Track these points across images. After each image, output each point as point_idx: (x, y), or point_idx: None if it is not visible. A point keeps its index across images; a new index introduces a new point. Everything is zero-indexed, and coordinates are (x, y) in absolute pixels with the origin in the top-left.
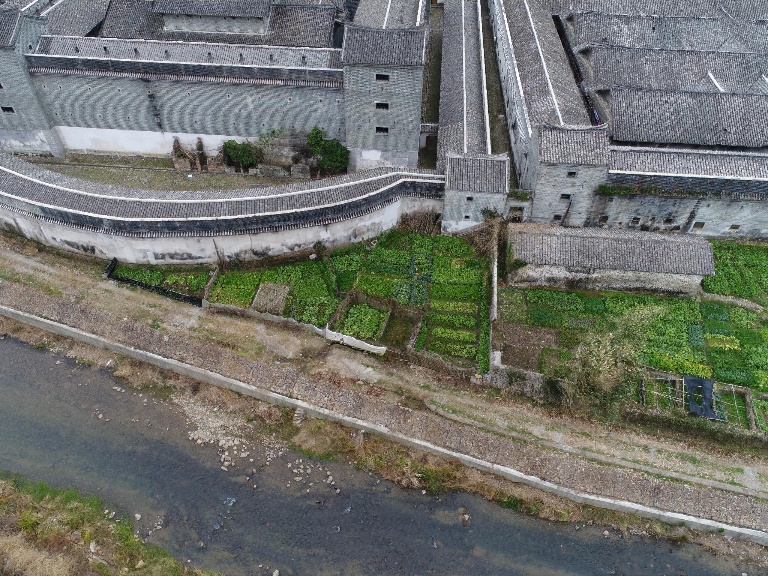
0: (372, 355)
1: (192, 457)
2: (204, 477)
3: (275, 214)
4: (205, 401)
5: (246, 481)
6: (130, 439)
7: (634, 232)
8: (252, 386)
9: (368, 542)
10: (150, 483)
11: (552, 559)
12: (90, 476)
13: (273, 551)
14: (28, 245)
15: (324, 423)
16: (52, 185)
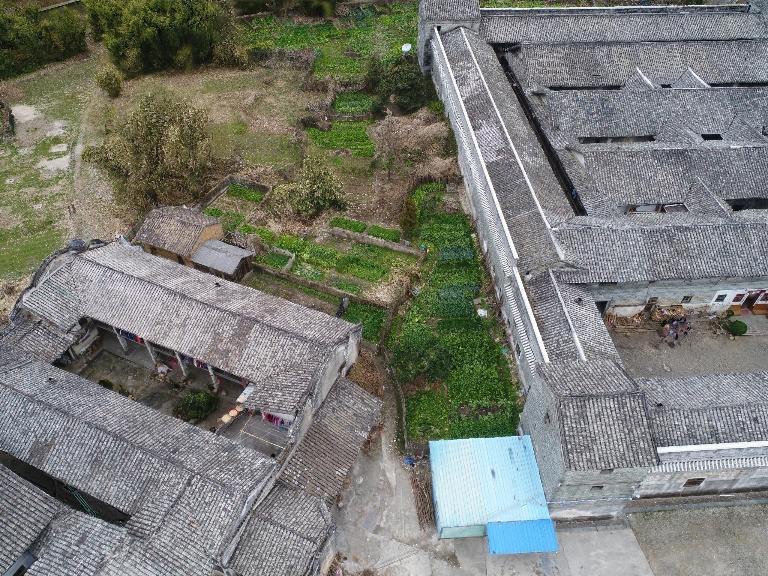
0: None
1: None
2: None
3: None
4: None
5: None
6: None
7: None
8: None
9: None
10: None
11: None
12: None
13: None
14: None
15: None
16: None
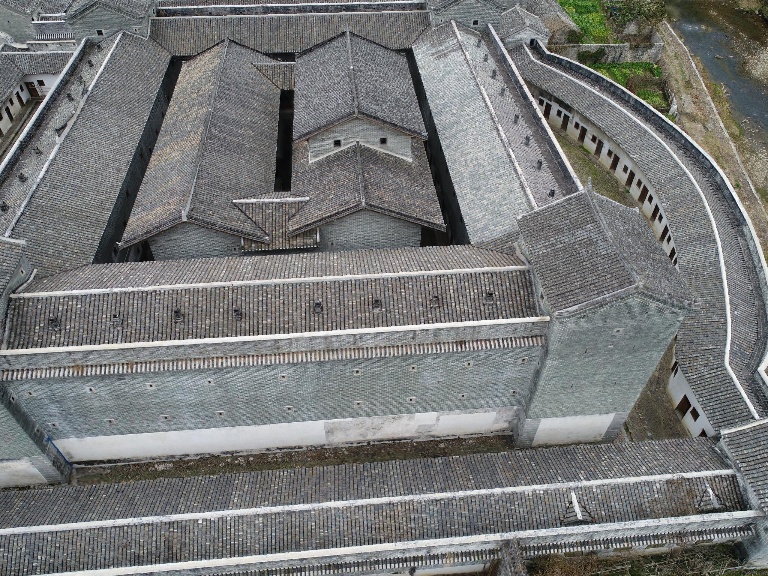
0: None
1: None
2: None
3: None
4: None
5: None
6: None
7: (529, 1)
8: (730, 143)
9: None
10: None
11: (717, 66)
12: None
13: None
14: None
15: None
16: None
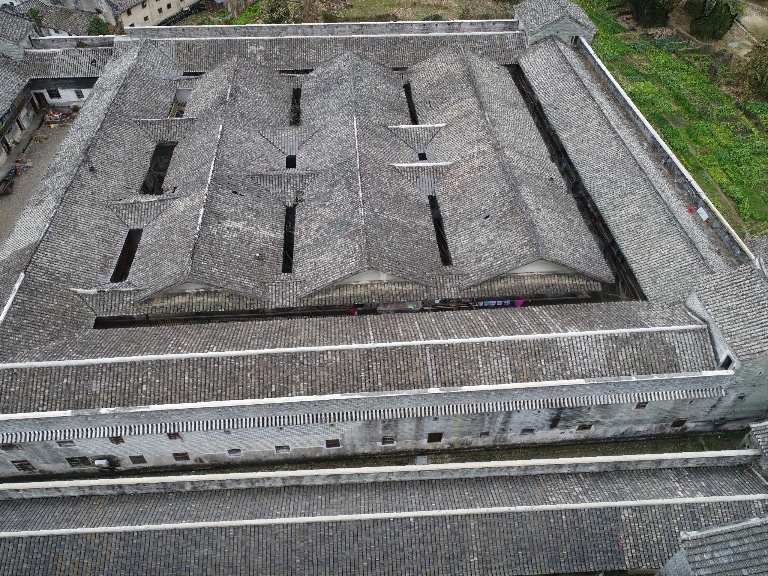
0: None
1: None
2: None
3: None
4: None
5: None
6: None
7: None
8: None
9: None
10: None
11: None
12: None
13: None
14: None
15: None
16: None
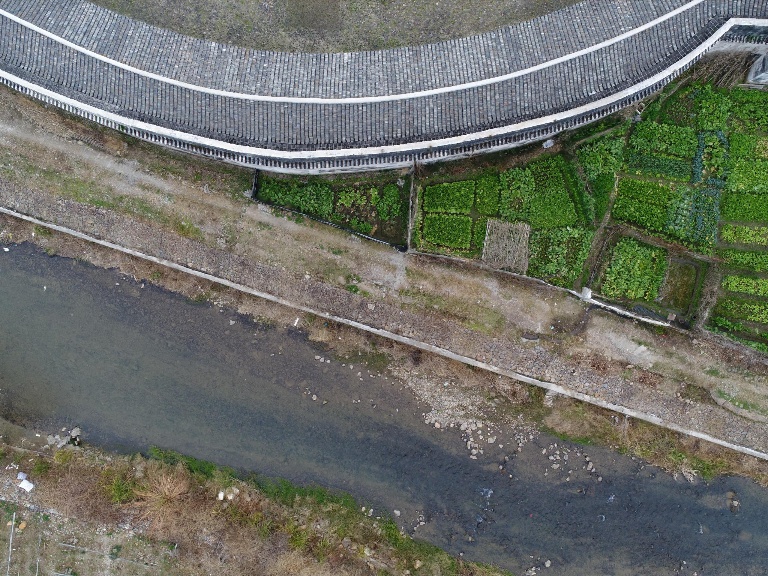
0: (645, 326)
1: (434, 443)
2: (453, 466)
3: (522, 128)
4: (431, 373)
5: (499, 470)
6: (358, 424)
7: None
8: (493, 366)
9: (634, 530)
10: (397, 474)
11: None
12: (330, 469)
13: (540, 541)
14: (107, 135)
15: (582, 407)
16: (124, 66)
